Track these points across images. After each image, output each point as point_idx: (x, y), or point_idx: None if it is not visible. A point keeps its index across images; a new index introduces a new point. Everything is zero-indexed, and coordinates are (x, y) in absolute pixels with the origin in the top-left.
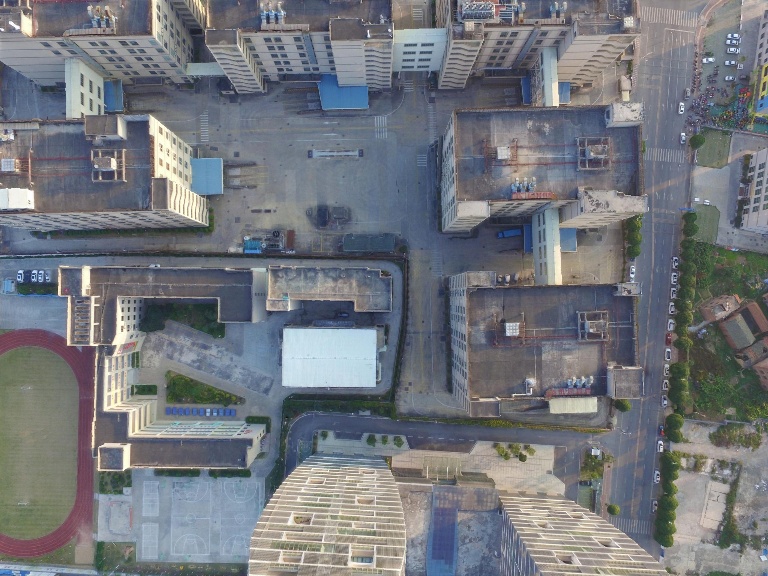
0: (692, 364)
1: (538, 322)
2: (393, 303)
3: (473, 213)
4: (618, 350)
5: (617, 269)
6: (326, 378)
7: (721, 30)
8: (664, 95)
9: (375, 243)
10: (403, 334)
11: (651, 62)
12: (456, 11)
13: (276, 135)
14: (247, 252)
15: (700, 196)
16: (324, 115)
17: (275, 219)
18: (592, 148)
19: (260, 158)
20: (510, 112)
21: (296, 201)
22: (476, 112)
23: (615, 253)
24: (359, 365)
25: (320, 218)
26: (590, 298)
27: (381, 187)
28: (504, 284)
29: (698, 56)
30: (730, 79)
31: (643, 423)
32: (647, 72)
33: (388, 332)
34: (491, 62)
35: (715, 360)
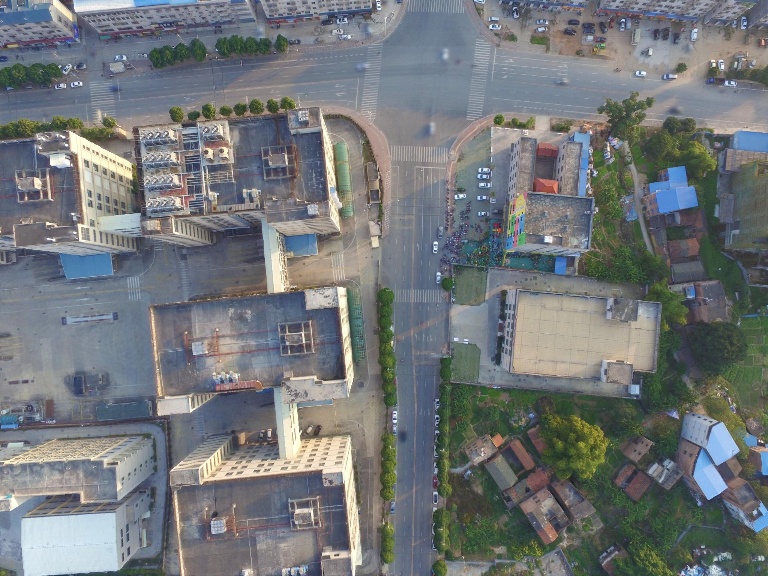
0: (454, 510)
1: (251, 512)
2: (158, 465)
3: (173, 411)
4: (333, 534)
5: (381, 414)
6: (67, 565)
7: (472, 164)
8: (418, 235)
9: (129, 411)
10: (167, 498)
11: (403, 202)
12: (145, 205)
13: (29, 304)
14: (3, 427)
15: (460, 335)
16: (75, 280)
17: (33, 389)
18: (287, 337)
19: (14, 329)
20: (211, 301)
21: (53, 369)
22: (176, 304)
23: (378, 399)
24: (99, 550)
25: (75, 387)
26: (302, 484)
27: (138, 349)
28: (267, 439)
29: (450, 192)
30: (482, 215)
31: (415, 567)
32: (399, 212)
33: (154, 495)
34: (224, 226)
35: (481, 501)
